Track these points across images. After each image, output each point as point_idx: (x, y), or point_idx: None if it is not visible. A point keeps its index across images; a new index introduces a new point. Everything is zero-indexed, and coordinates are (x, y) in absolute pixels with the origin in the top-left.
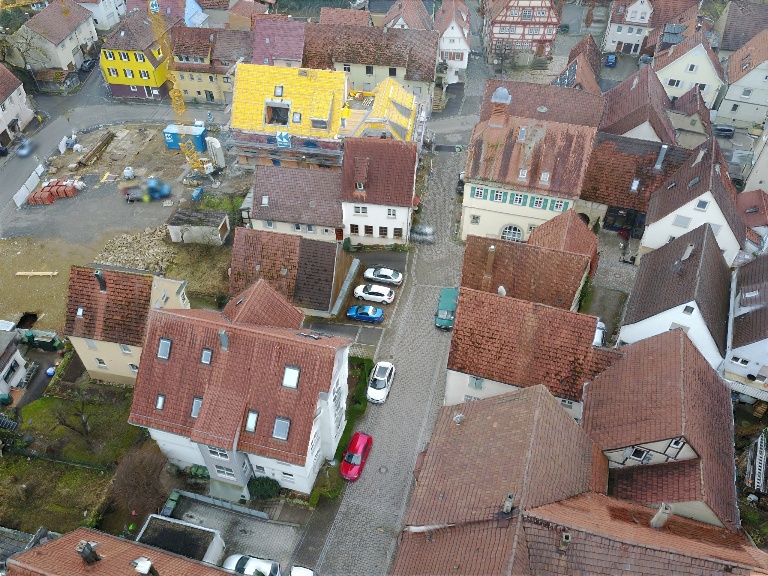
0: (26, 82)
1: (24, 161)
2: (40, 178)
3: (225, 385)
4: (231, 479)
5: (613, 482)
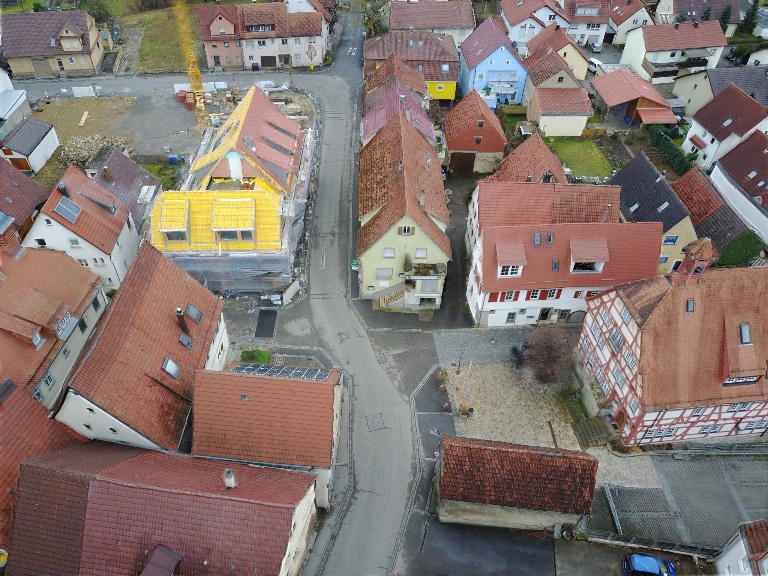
0: None
1: (247, 79)
2: (220, 91)
3: None
4: None
5: None
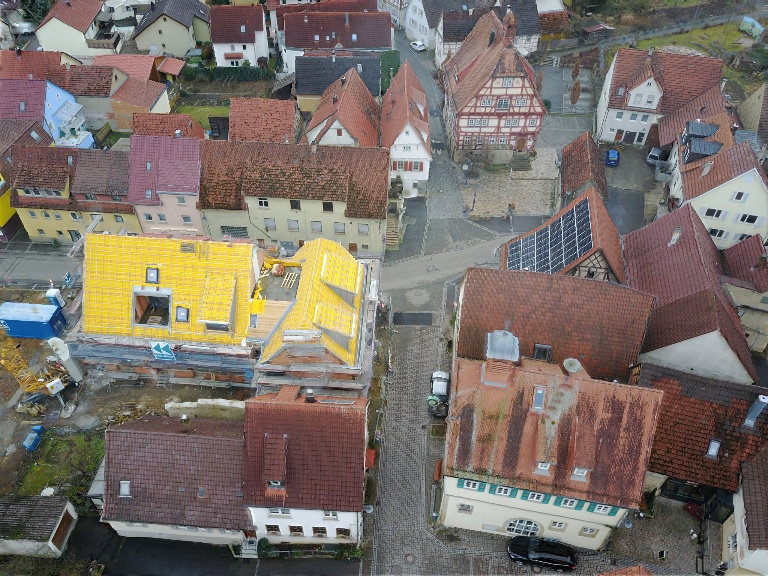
0: None
1: None
2: None
3: None
4: None
5: None
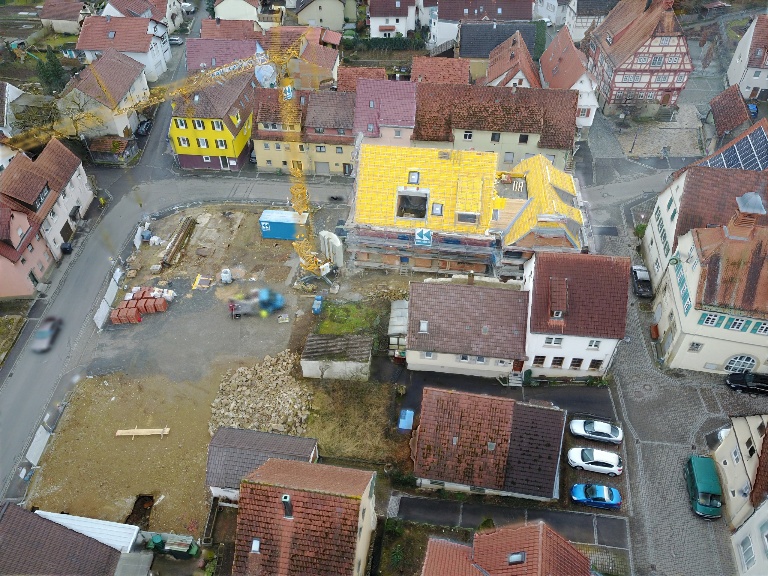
0: (78, 153)
1: (93, 260)
2: (117, 284)
3: None
4: None
5: None
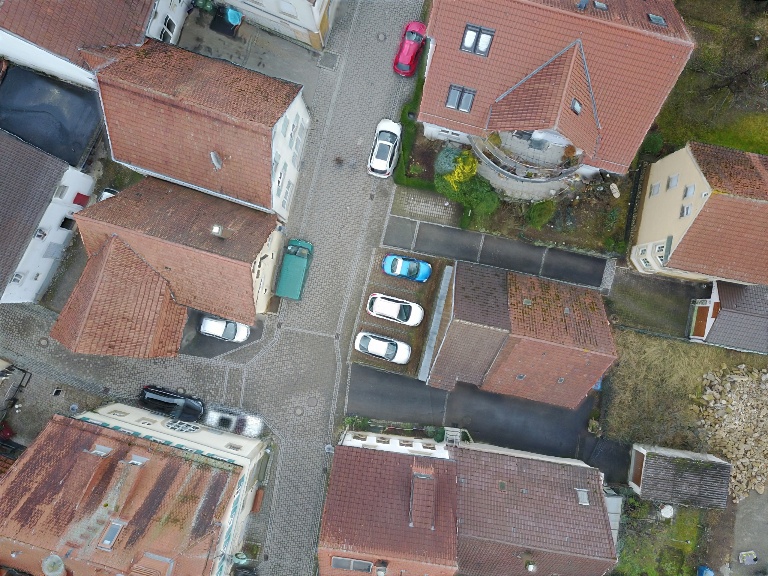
0: None
1: None
2: None
3: None
4: None
5: None
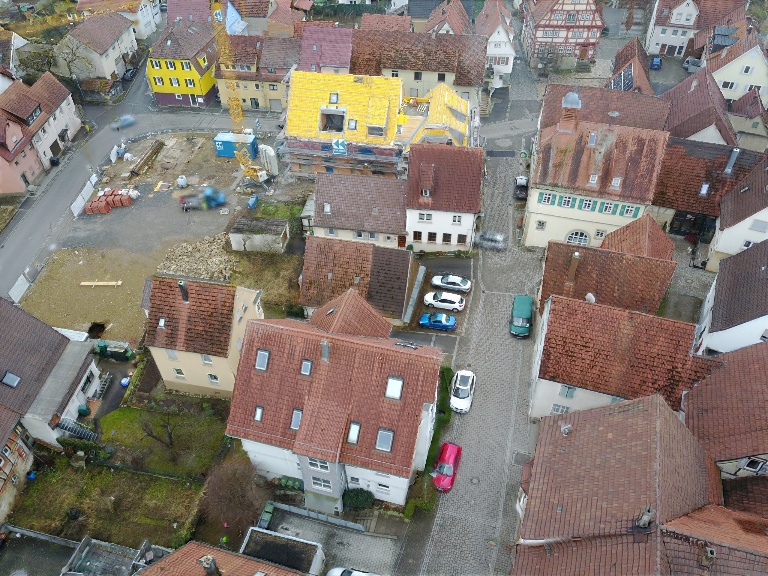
0: (71, 92)
1: (76, 171)
2: (94, 187)
3: (325, 396)
4: (327, 491)
5: (727, 493)
